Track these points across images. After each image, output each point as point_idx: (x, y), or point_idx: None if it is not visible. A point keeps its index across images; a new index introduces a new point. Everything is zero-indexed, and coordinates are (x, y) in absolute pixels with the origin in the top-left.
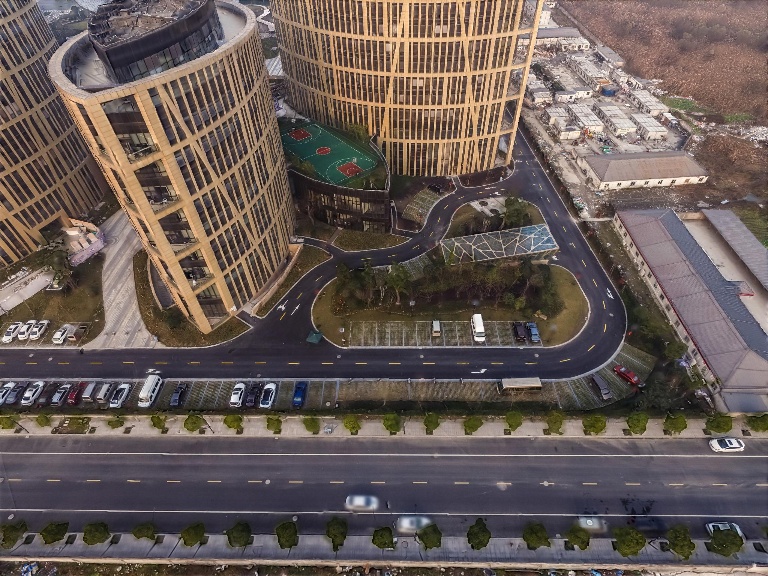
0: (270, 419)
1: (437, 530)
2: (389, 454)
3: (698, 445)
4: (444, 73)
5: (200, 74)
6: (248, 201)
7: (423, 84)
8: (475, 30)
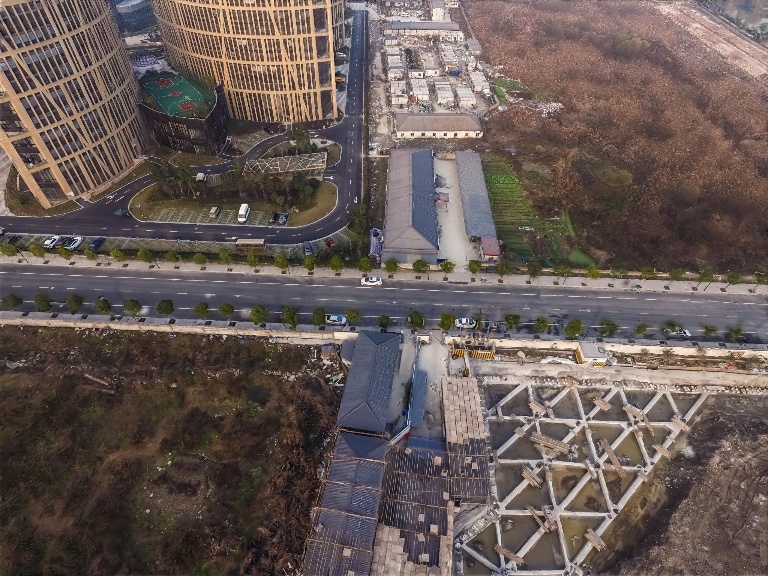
0: (60, 248)
1: (137, 302)
2: (142, 278)
3: (354, 282)
4: (260, 35)
5: (17, 8)
6: (77, 111)
7: (246, 44)
8: (276, 2)
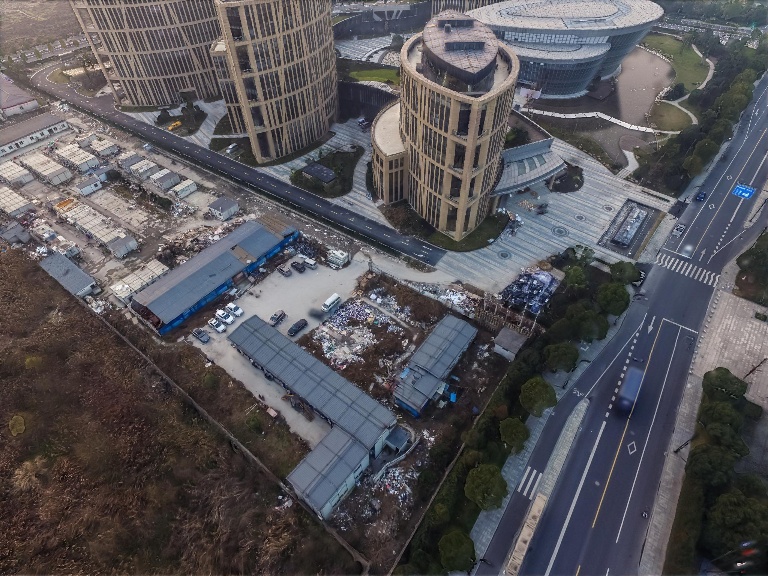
0: None
1: (74, 31)
2: None
3: None
4: None
5: None
6: None
7: None
8: None
